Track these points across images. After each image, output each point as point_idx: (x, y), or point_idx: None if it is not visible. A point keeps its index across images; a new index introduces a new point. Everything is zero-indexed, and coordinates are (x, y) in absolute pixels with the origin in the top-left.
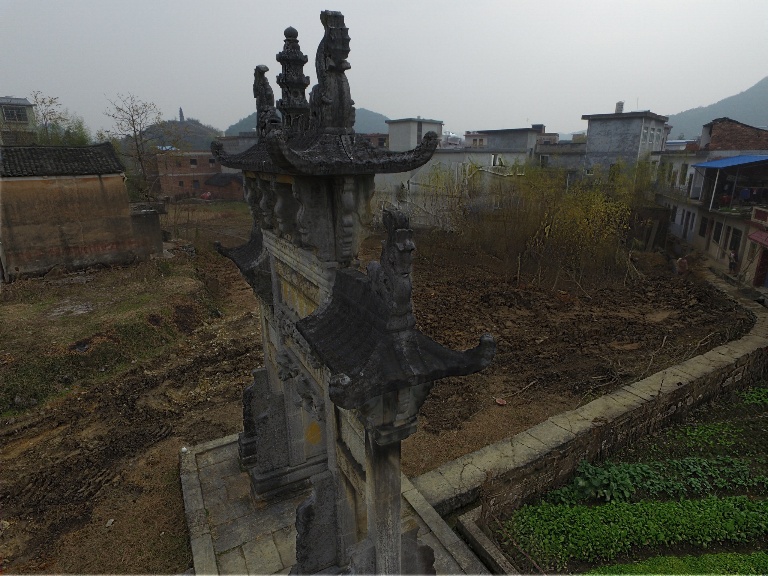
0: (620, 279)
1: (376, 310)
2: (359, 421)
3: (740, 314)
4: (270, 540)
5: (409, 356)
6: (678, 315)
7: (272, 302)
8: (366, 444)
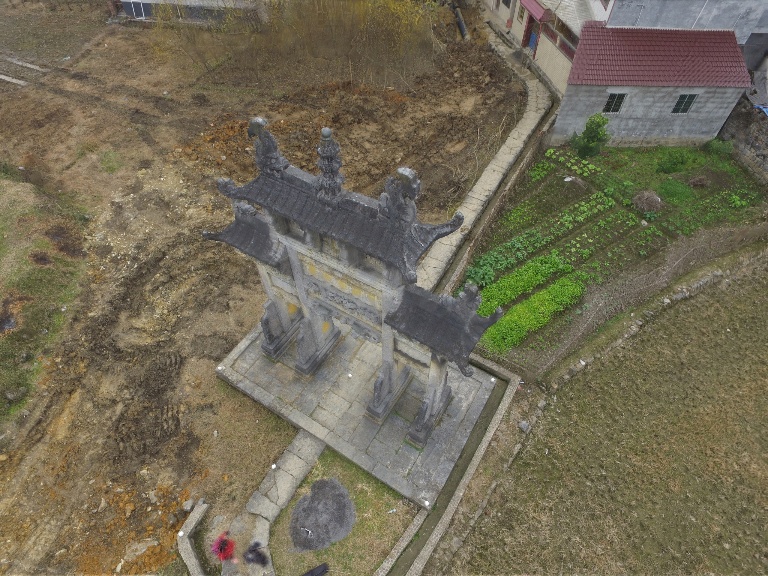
0: (427, 55)
1: (453, 319)
2: (425, 349)
3: (517, 84)
4: (332, 394)
5: (471, 332)
6: (481, 100)
7: (291, 273)
8: (434, 358)
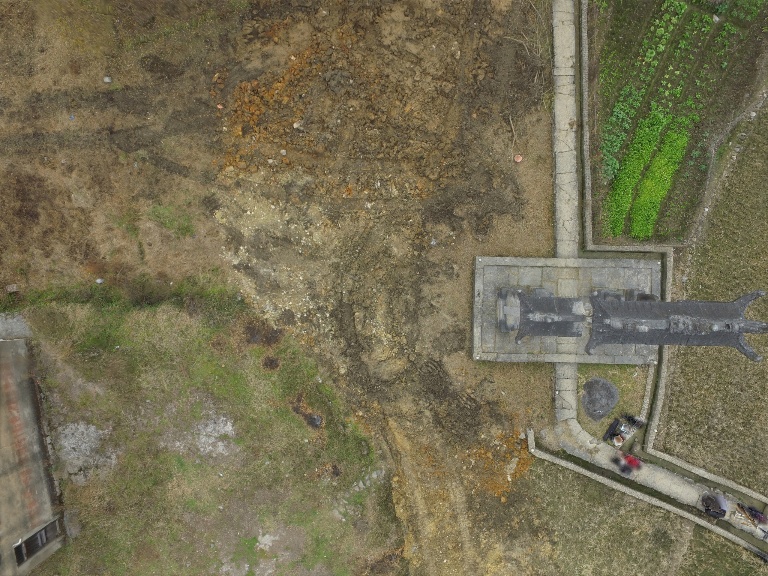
0: None
1: None
2: None
3: None
4: None
5: None
6: None
7: None
8: None
